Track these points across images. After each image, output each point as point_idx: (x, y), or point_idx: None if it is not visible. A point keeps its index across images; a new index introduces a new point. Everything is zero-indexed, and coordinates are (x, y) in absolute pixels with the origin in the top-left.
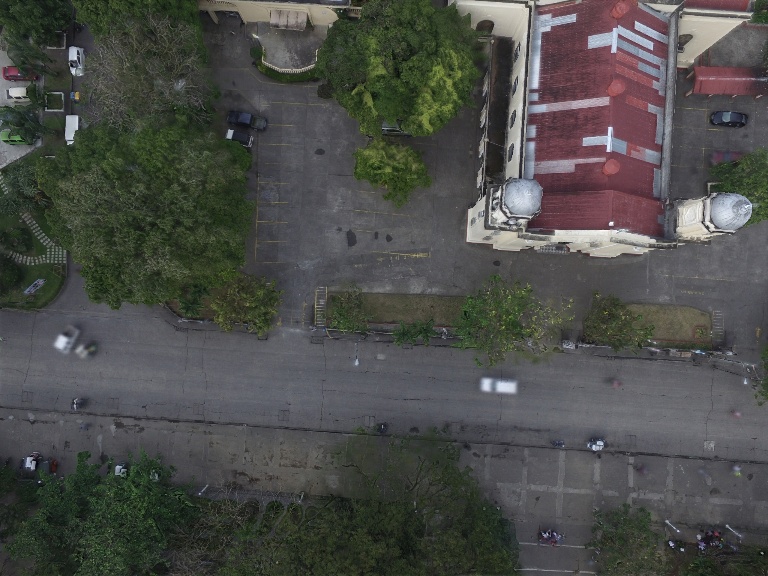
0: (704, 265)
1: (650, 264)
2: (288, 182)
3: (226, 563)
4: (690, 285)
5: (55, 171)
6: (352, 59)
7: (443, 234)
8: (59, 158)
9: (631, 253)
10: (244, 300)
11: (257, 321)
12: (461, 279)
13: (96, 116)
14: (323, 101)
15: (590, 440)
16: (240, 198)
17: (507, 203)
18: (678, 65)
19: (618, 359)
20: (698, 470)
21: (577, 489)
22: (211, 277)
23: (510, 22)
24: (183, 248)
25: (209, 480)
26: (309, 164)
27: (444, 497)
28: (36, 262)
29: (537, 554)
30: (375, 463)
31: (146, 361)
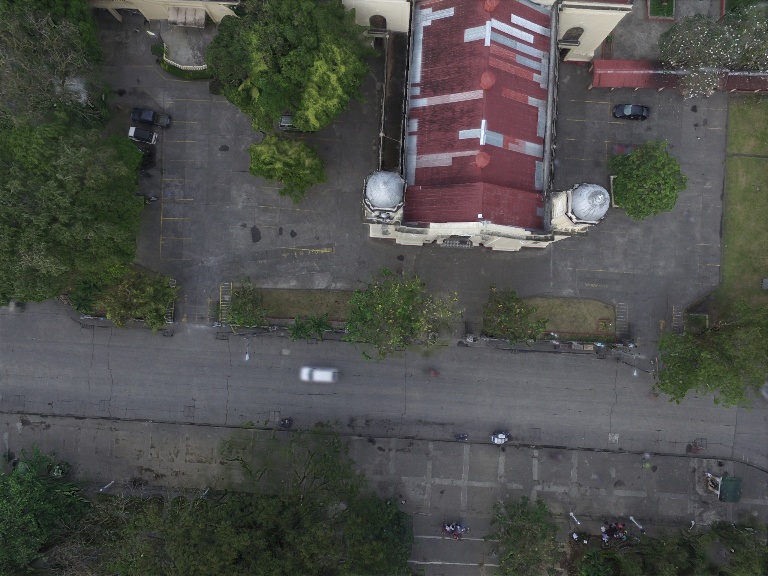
0: (608, 258)
1: (554, 257)
2: (193, 179)
3: (110, 558)
4: (594, 278)
5: None
6: (235, 55)
7: (347, 229)
8: None
9: (534, 246)
10: (136, 296)
11: (148, 317)
12: (365, 274)
13: None
14: None
15: (494, 433)
16: (128, 194)
17: (368, 196)
18: (579, 59)
19: (522, 352)
20: (602, 462)
21: (482, 482)
22: (100, 273)
23: (400, 17)
24: (64, 244)
25: (115, 476)
26: (213, 161)
27: (327, 490)
28: None
29: (442, 547)
30: (280, 458)
31: (52, 358)
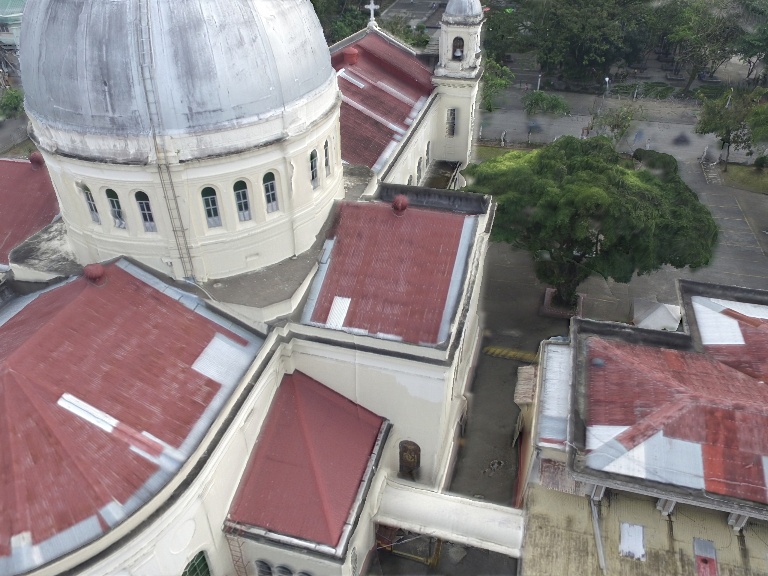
0: None
1: None
2: (716, 244)
3: None
4: None
5: None
6: None
7: None
8: None
9: None
10: None
11: None
12: None
13: None
14: None
15: None
16: None
17: None
18: None
19: None
20: None
21: None
22: None
23: None
24: None
25: None
26: None
27: None
28: None
29: None
30: None
31: None
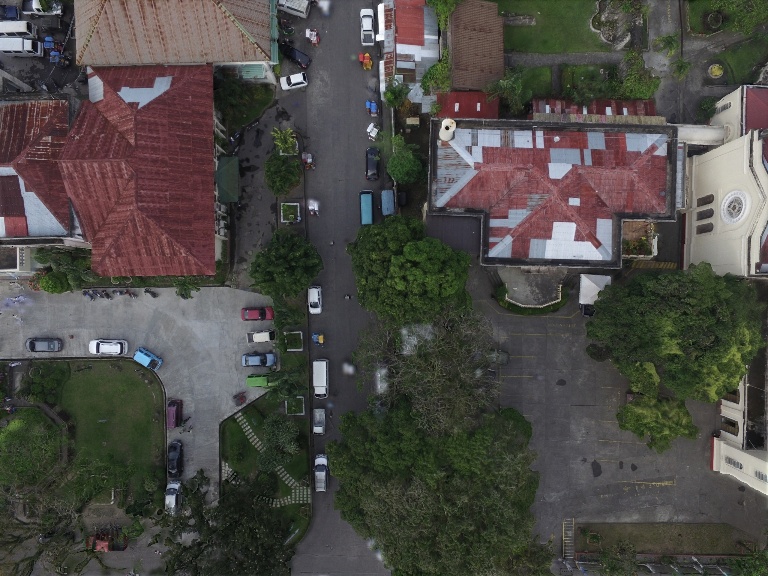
0: None
1: None
2: (531, 414)
3: None
4: None
5: (352, 463)
6: (644, 338)
7: (687, 461)
8: (356, 449)
9: None
10: (527, 567)
11: None
12: (707, 506)
13: (381, 396)
14: (563, 331)
15: None
16: None
17: None
18: None
19: None
20: None
21: None
22: None
23: None
24: None
25: None
26: (551, 395)
27: None
28: (282, 504)
29: None
30: None
31: None
